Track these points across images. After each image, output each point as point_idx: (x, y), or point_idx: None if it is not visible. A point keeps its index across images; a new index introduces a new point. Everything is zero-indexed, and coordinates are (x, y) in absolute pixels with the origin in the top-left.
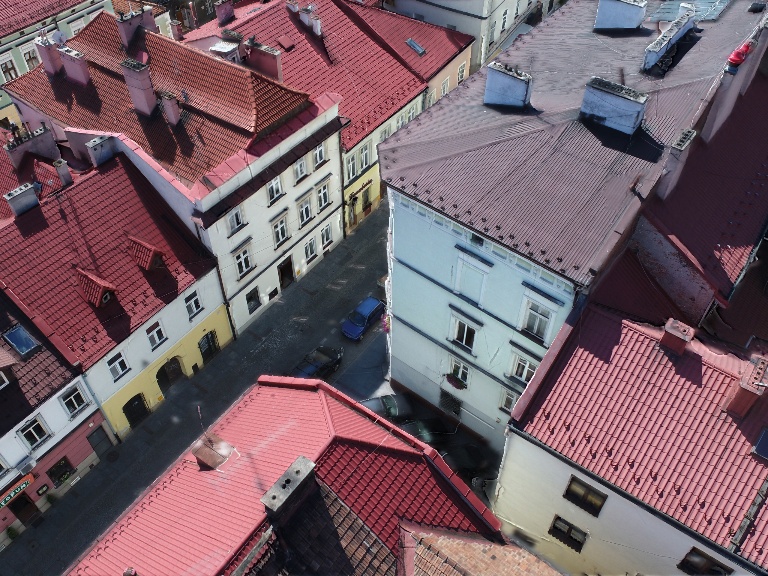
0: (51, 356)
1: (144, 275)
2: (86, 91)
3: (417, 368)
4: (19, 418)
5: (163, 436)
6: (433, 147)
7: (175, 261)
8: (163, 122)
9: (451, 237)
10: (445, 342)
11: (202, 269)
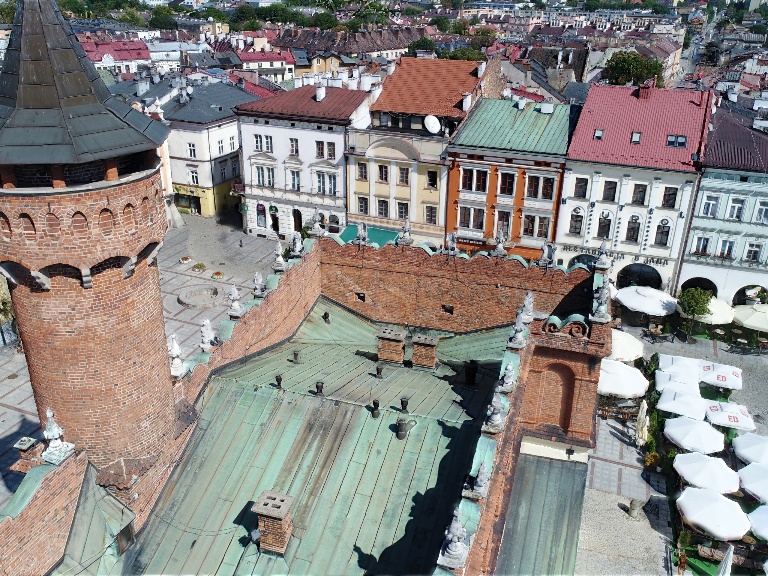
0: None
1: None
2: None
3: None
4: None
5: None
6: None
7: None
8: None
9: None
10: None
11: None
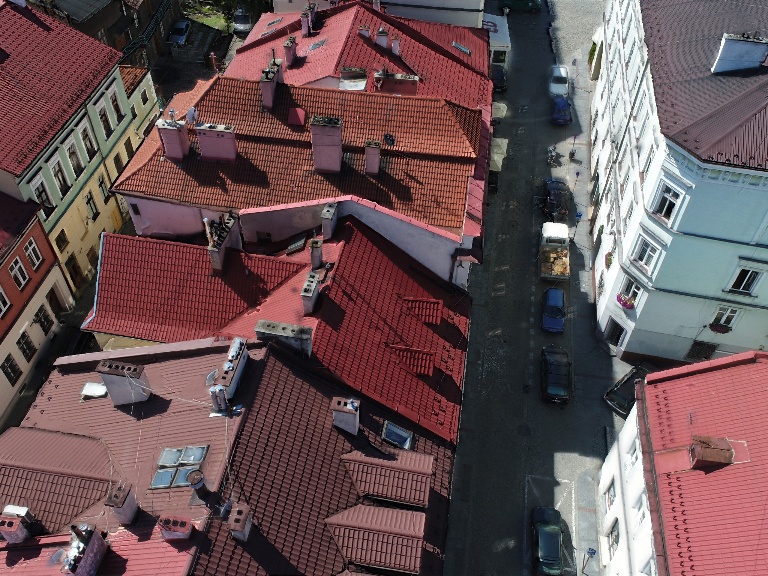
0: (426, 441)
1: (433, 331)
2: (237, 166)
3: (666, 331)
4: (446, 514)
5: (471, 488)
6: (718, 120)
7: (443, 308)
8: (358, 174)
9: (765, 193)
10: (718, 295)
11: (466, 308)
